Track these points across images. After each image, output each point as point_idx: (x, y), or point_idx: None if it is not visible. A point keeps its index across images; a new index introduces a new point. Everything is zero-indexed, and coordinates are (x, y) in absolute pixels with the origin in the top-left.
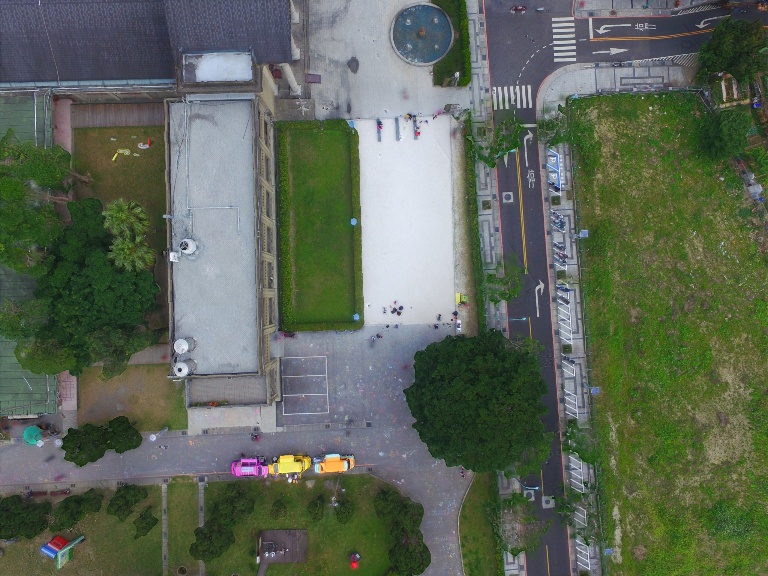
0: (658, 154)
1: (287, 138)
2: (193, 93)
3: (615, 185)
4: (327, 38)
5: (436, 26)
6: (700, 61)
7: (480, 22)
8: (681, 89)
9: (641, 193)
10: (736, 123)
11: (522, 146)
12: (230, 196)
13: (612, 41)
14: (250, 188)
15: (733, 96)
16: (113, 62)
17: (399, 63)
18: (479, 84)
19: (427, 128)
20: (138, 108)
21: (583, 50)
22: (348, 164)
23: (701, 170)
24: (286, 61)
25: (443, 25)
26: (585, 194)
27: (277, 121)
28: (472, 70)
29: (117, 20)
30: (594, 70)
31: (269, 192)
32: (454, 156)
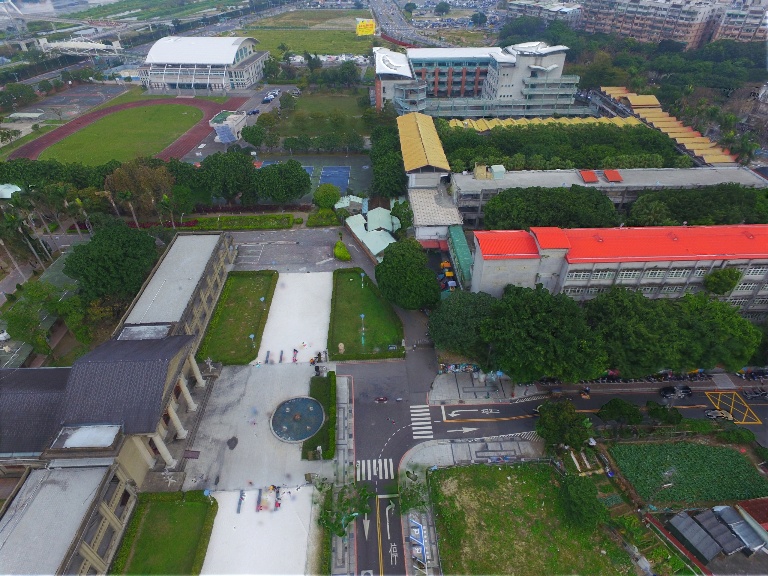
0: (526, 524)
1: (146, 510)
2: (53, 458)
3: (486, 560)
4: (216, 422)
5: (311, 412)
6: (539, 435)
7: (349, 409)
8: (532, 460)
9: (518, 570)
10: (581, 486)
11: (384, 517)
12: (36, 567)
13: (463, 422)
14: (63, 557)
15: (586, 466)
16: (9, 438)
17: (274, 441)
18: (344, 458)
19: (289, 499)
20: (16, 482)
21: (438, 429)
22: (199, 538)
23: (577, 542)
24: (150, 431)
25: (317, 412)
26: (453, 572)
27: (141, 493)
28: (339, 446)
29: (32, 406)
30: (450, 445)
31: (98, 570)
32: (312, 528)
